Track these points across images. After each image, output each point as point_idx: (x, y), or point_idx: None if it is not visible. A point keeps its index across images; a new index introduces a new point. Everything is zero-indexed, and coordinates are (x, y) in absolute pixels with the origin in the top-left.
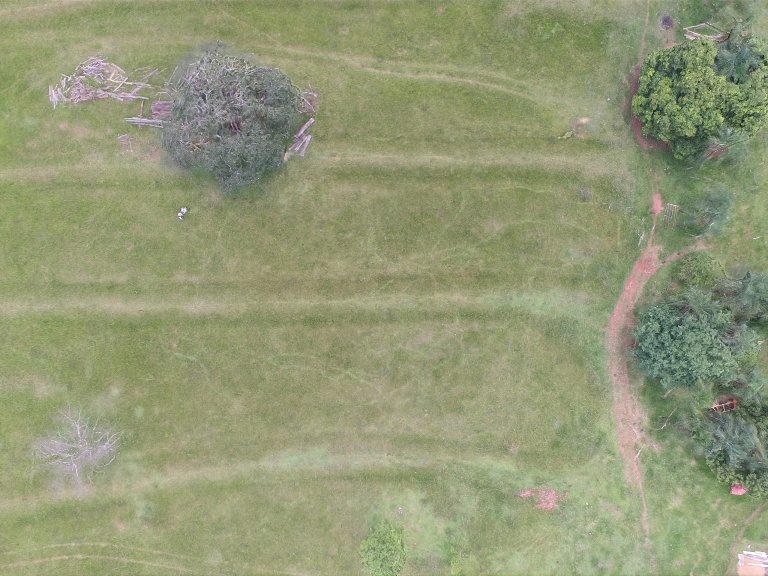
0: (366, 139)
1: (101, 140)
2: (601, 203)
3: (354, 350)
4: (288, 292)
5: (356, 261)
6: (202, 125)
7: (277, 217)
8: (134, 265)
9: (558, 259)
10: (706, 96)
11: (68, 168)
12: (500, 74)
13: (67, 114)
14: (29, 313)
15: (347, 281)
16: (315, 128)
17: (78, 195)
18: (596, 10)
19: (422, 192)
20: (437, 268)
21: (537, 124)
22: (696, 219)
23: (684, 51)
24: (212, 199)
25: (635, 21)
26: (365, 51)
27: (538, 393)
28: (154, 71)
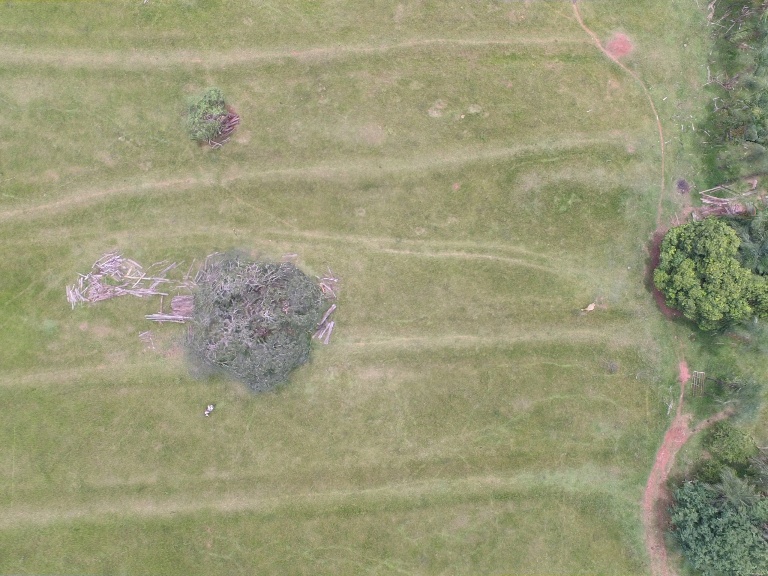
0: (389, 322)
1: (122, 339)
2: (628, 374)
3: (390, 539)
4: (320, 483)
5: (386, 448)
6: (229, 346)
7: (304, 407)
8: (163, 465)
9: (589, 434)
10: (732, 288)
11: (90, 370)
12: (519, 248)
13: (86, 314)
14: (59, 522)
15: (379, 468)
16: (337, 314)
17: (102, 397)
18: (611, 178)
19: (448, 373)
20: (468, 450)
21: (559, 297)
22: (724, 387)
23: (707, 240)
24: (238, 393)
25: (651, 187)
26: (383, 232)
27: (577, 572)
28: (172, 265)
